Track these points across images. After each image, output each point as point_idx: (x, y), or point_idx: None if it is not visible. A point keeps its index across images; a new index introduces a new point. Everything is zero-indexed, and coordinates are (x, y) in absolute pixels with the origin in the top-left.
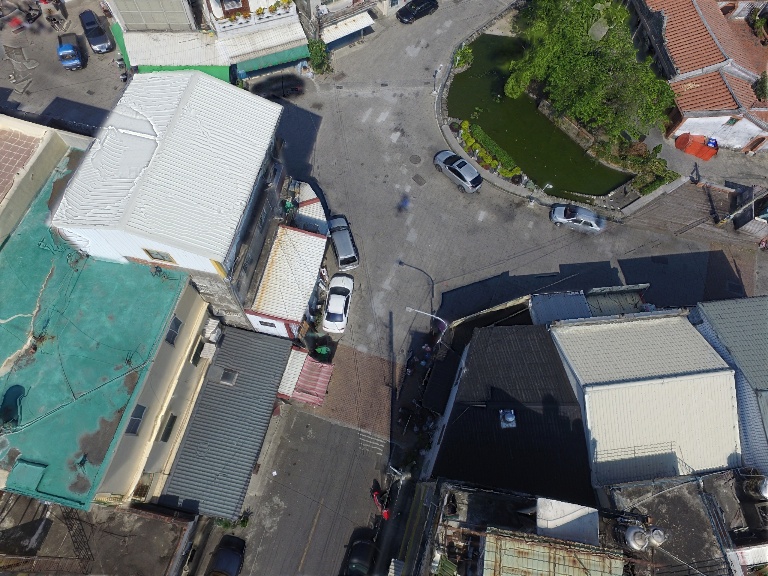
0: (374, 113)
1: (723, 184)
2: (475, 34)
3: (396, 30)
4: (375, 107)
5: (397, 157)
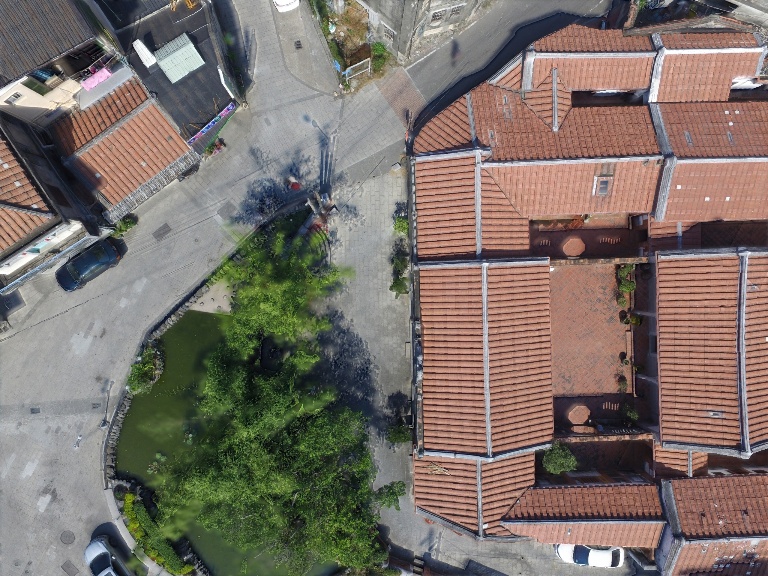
0: (18, 463)
1: (465, 565)
2: (171, 318)
3: (59, 300)
4: (20, 452)
5: (44, 535)
